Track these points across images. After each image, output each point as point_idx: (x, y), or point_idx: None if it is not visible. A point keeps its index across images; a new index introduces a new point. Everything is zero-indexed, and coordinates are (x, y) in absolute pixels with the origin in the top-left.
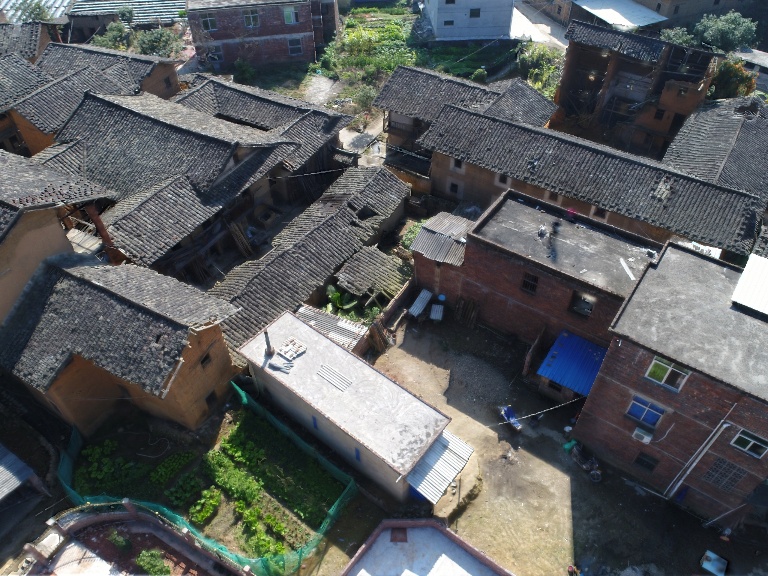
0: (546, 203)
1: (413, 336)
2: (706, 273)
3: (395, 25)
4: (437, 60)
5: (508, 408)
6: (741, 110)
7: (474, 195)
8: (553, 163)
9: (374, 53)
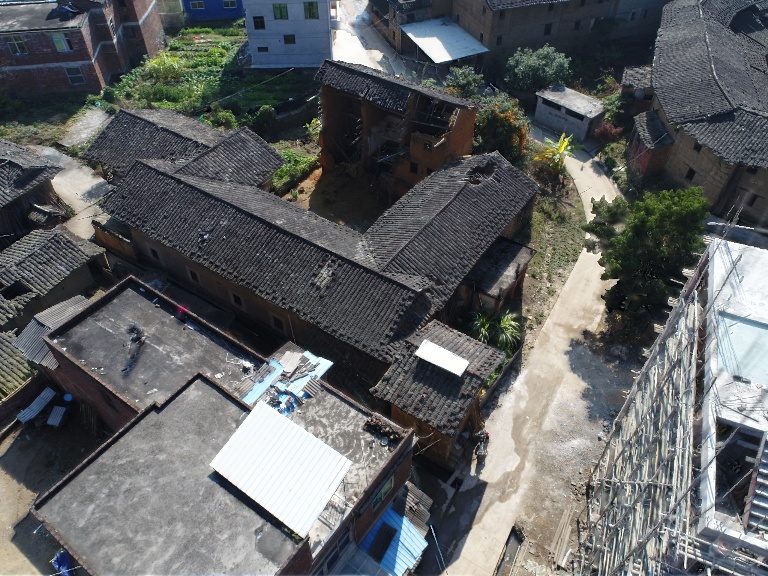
0: (161, 296)
1: (21, 446)
2: (216, 420)
3: (220, 48)
4: (246, 90)
5: (61, 554)
6: (483, 169)
7: (172, 263)
8: (223, 237)
9: (181, 81)
